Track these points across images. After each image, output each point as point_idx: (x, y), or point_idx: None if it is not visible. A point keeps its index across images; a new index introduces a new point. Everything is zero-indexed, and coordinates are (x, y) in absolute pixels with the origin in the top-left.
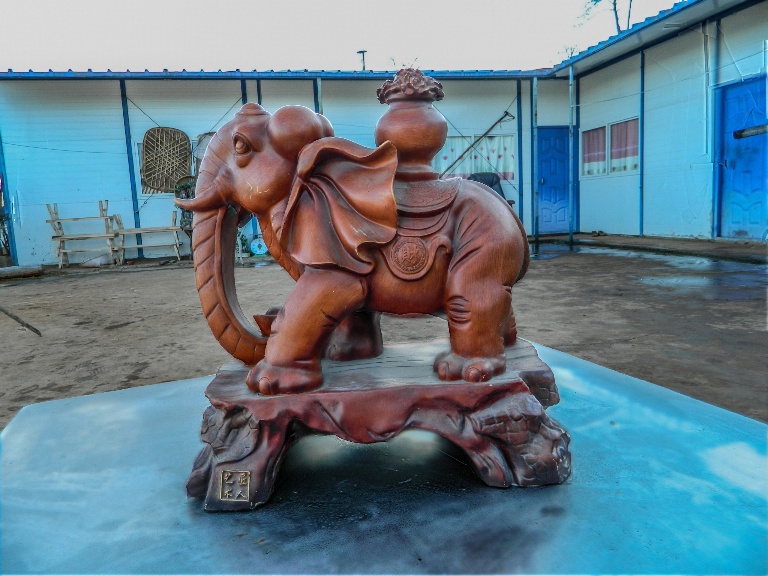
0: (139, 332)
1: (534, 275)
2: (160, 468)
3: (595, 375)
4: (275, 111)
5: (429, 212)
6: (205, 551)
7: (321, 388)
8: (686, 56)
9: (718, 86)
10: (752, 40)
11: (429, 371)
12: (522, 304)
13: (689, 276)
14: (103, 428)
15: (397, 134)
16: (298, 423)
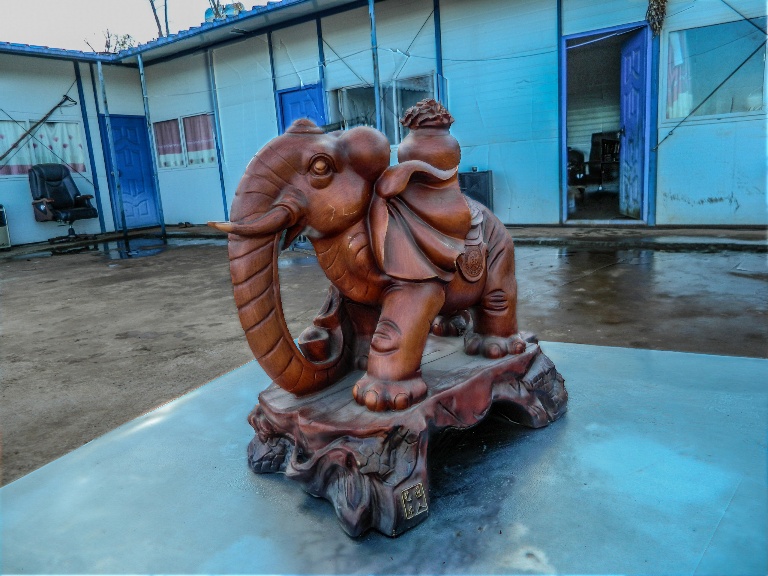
0: None
1: (154, 273)
2: (261, 536)
3: None
4: (359, 133)
5: None
6: (461, 558)
7: None
8: (250, 60)
9: (283, 91)
10: (309, 56)
11: (466, 356)
12: (169, 303)
13: (295, 257)
14: (74, 542)
15: (441, 158)
16: (430, 426)
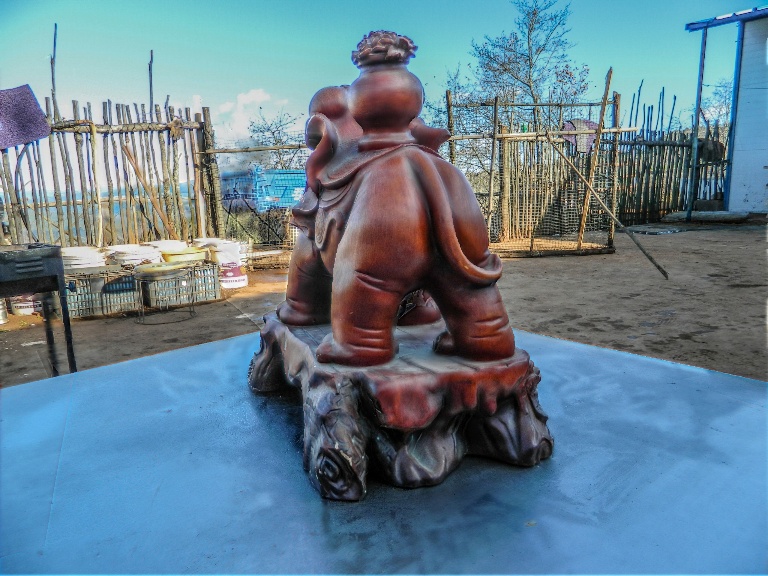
0: (755, 297)
1: None
2: None
3: (760, 503)
4: None
5: (330, 184)
6: None
7: (300, 326)
8: None
9: None
10: None
11: None
12: None
13: None
14: None
15: None
16: None
